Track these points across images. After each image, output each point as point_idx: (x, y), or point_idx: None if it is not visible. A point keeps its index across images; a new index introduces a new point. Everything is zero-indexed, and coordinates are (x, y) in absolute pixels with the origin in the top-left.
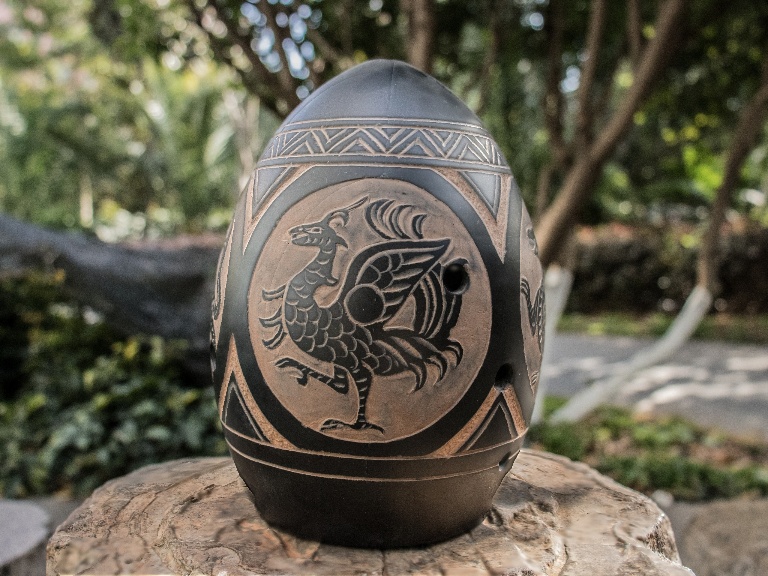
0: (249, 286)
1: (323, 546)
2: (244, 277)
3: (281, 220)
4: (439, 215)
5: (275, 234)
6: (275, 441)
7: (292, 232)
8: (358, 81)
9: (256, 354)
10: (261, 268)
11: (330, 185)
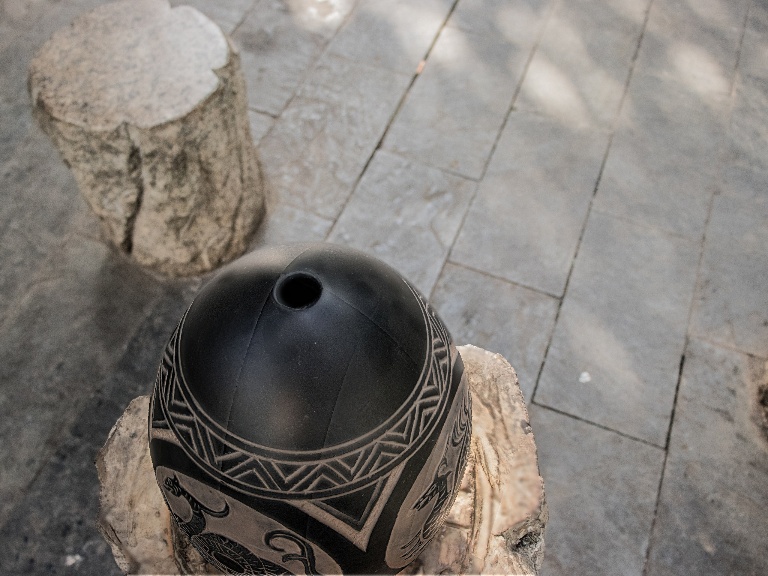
0: None
1: None
2: None
3: (400, 511)
4: (464, 387)
5: (399, 520)
6: None
7: None
8: (367, 362)
9: None
10: None
11: (427, 459)
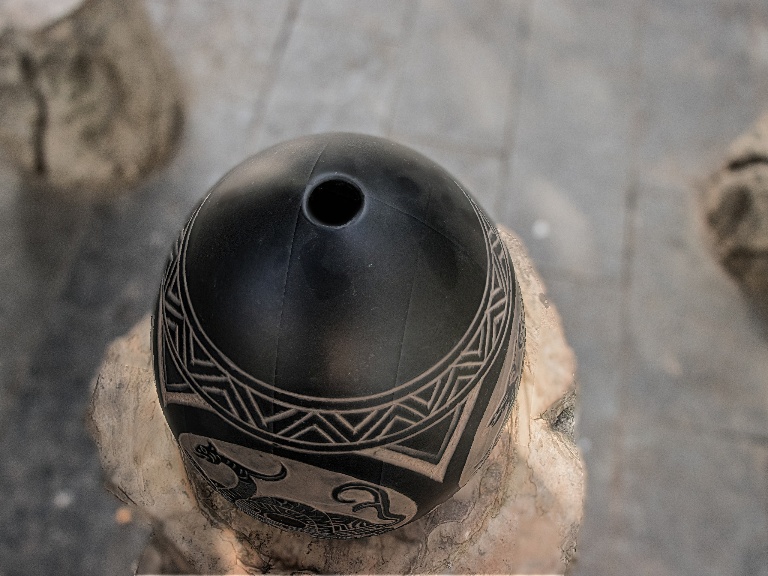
0: None
1: None
2: None
3: None
4: None
5: (475, 442)
6: None
7: None
8: (432, 277)
9: None
10: None
11: None
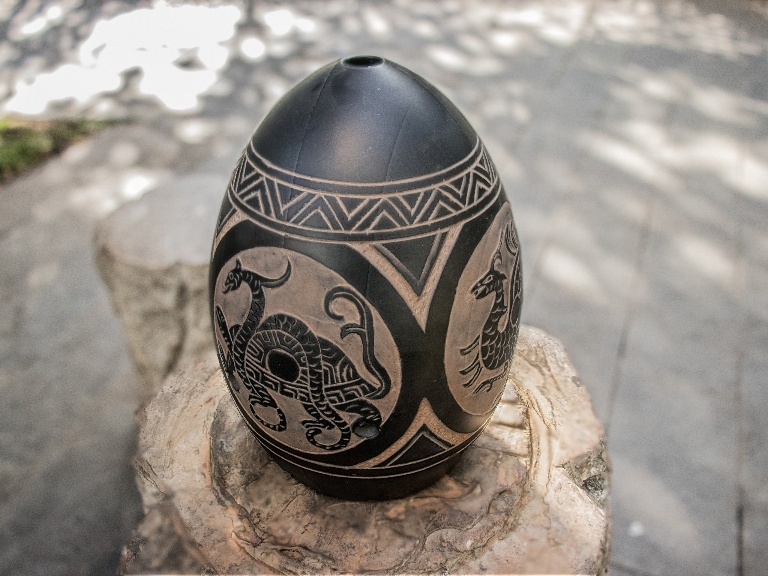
0: (444, 354)
1: (451, 474)
2: (435, 349)
3: (459, 285)
4: None
5: (458, 300)
6: (457, 441)
7: (474, 291)
8: (424, 113)
9: (455, 398)
10: (454, 334)
11: (483, 235)
